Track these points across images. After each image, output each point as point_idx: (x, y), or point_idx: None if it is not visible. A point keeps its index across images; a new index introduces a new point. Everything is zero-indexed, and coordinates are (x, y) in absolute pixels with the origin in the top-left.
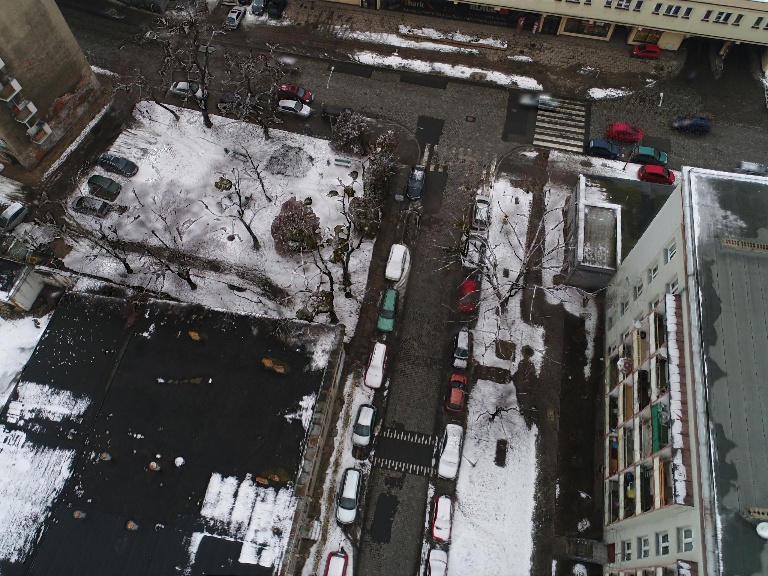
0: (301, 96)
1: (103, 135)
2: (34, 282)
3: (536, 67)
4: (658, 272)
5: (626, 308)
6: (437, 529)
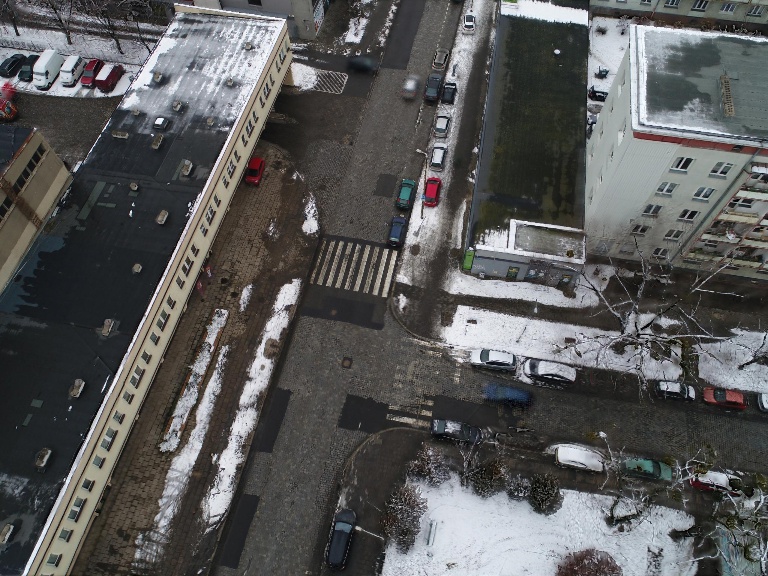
0: None
1: None
2: None
3: (263, 282)
4: (680, 184)
5: (639, 231)
6: None
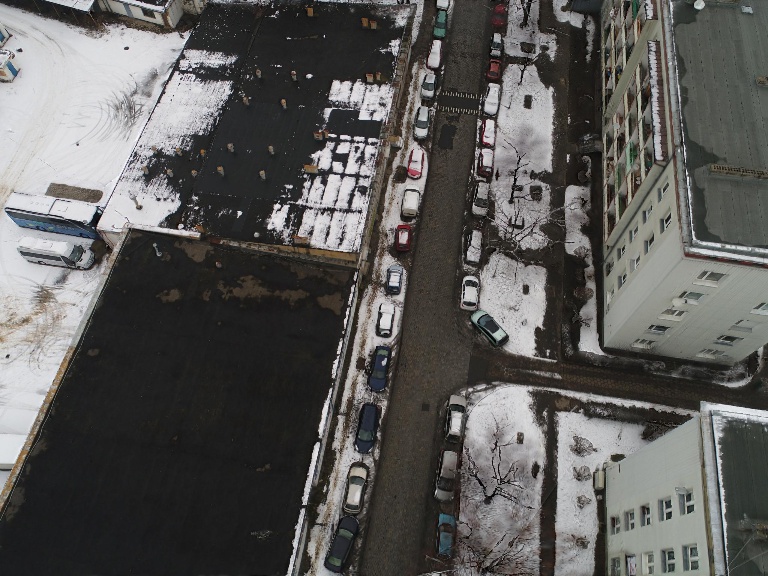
0: None
1: None
2: (179, 6)
3: None
4: None
5: None
6: (486, 137)
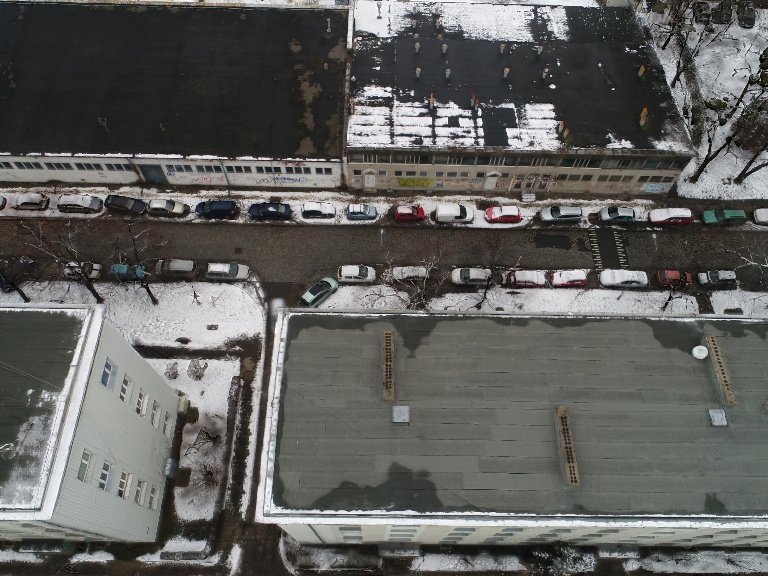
0: None
1: (767, 1)
2: None
3: None
4: None
5: None
6: (560, 274)
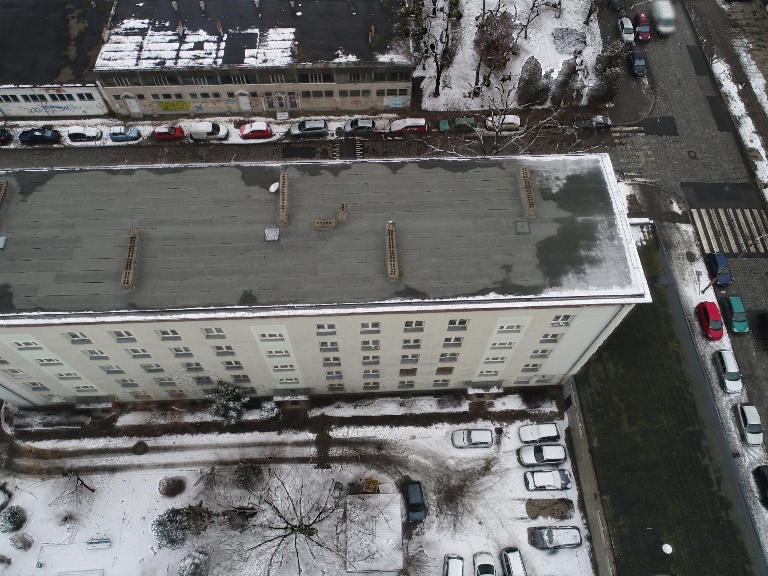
0: (641, 30)
1: None
2: None
3: None
4: None
5: None
6: None
